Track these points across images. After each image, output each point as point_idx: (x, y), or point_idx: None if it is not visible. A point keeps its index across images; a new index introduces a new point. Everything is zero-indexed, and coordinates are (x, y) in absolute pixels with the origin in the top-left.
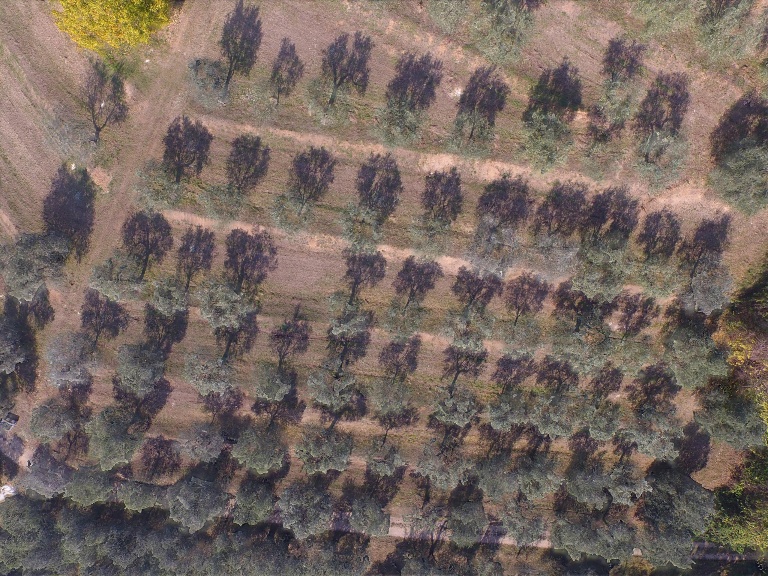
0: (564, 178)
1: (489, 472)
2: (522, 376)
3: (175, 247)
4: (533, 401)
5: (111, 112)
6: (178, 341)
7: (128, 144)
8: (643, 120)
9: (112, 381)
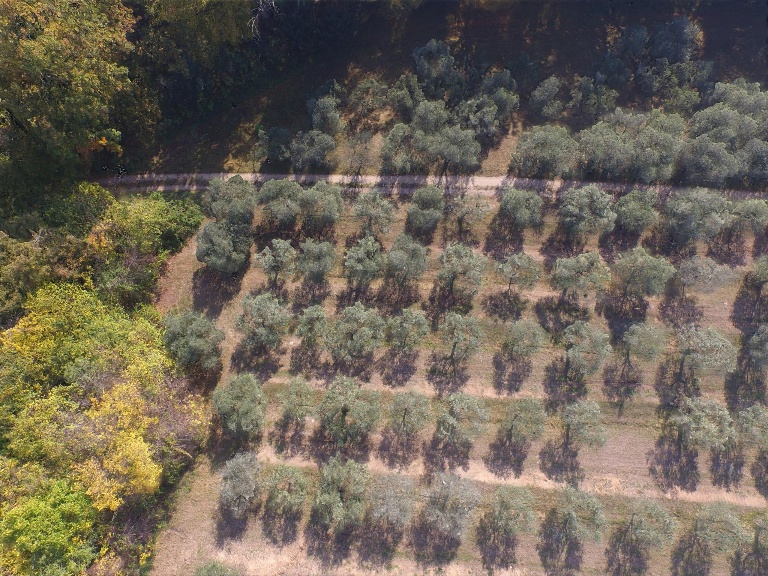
0: (383, 575)
1: None
2: (389, 357)
3: (748, 467)
4: None
5: None
6: None
7: None
8: None
9: None
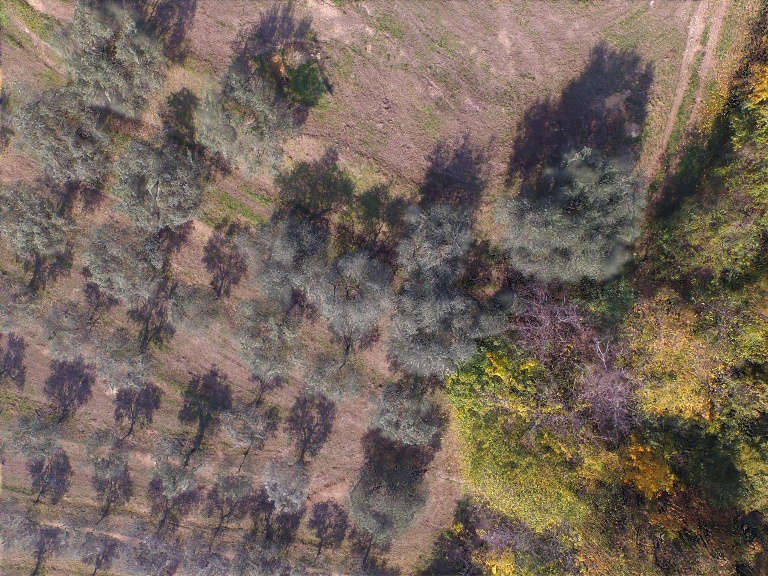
0: (226, 471)
1: None
2: None
3: None
4: None
5: None
6: None
7: None
8: (295, 424)
9: None
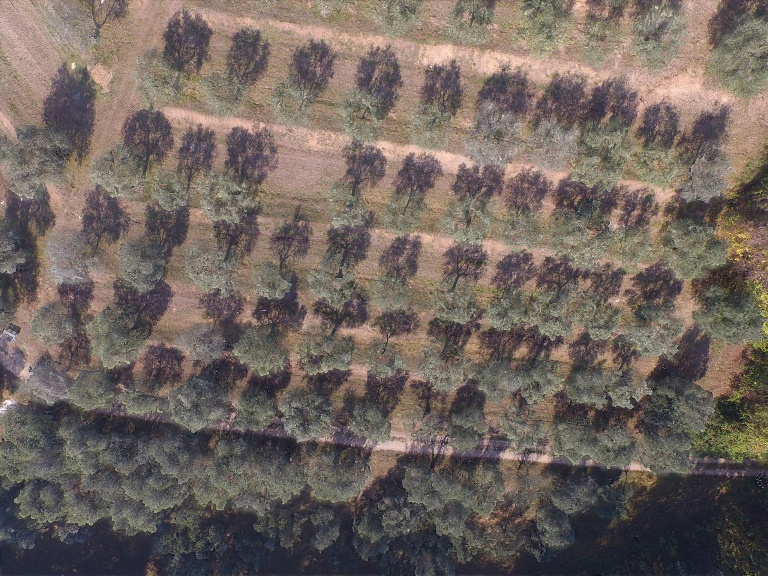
0: (563, 69)
1: (489, 374)
2: (522, 280)
3: (175, 147)
4: (533, 306)
5: (111, 8)
6: (179, 244)
7: (128, 41)
8: (642, 8)
9: (113, 287)
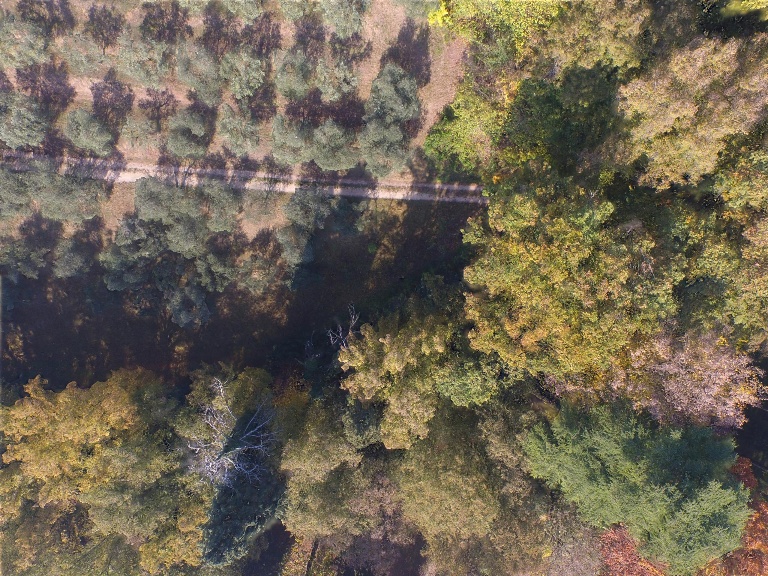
0: None
1: None
2: None
3: None
4: None
5: None
6: None
7: None
8: None
9: None
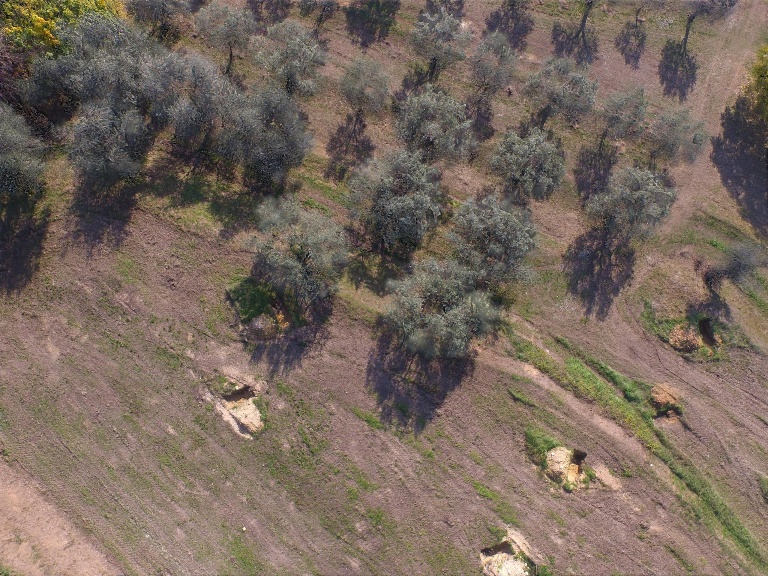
0: None
1: None
2: None
3: None
4: None
5: None
6: None
7: None
8: (284, 2)
9: None
